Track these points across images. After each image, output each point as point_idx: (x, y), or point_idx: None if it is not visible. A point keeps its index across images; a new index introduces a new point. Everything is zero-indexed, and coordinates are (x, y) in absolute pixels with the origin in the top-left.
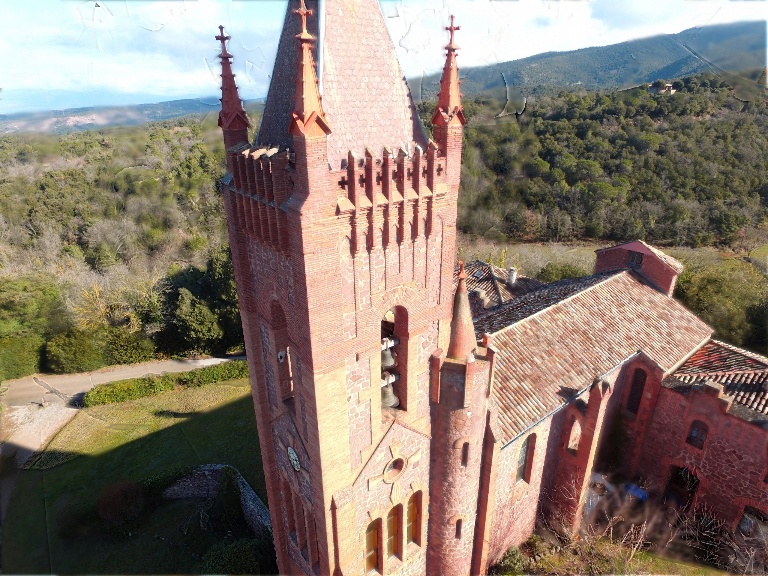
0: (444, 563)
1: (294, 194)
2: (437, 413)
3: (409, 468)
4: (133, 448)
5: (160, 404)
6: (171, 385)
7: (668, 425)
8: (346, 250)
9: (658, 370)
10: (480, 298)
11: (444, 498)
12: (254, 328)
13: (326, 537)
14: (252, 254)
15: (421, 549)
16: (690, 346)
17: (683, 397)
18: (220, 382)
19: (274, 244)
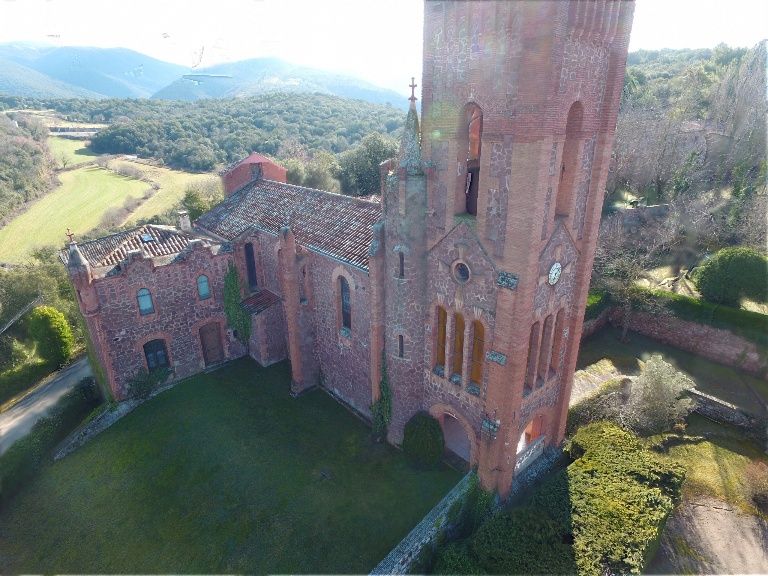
0: None
1: None
2: None
3: None
4: None
5: None
6: None
7: None
8: None
9: None
10: (204, 247)
11: None
12: None
13: None
14: None
15: None
16: None
17: None
18: None
19: None
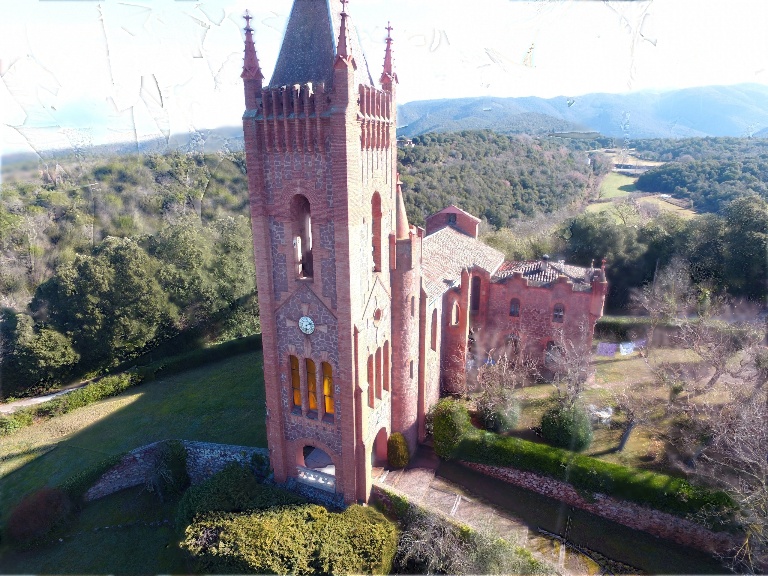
0: (404, 402)
1: (334, 106)
2: (394, 278)
3: (383, 319)
4: (12, 479)
5: (20, 440)
6: (28, 419)
7: (498, 309)
8: (359, 145)
9: (486, 273)
10: None
11: (402, 345)
12: (266, 229)
13: (351, 359)
14: (269, 168)
15: (389, 394)
16: (497, 262)
17: (503, 286)
18: (91, 403)
19: (310, 145)
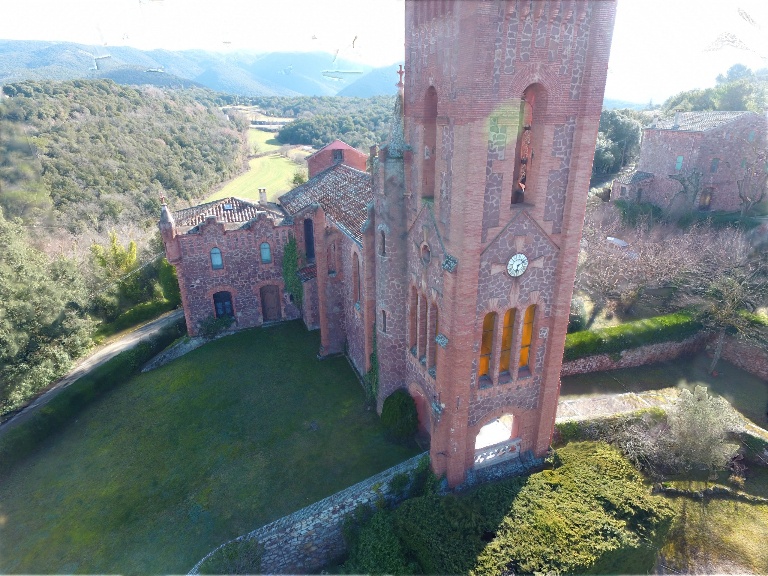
0: None
1: None
2: None
3: None
4: None
5: None
6: None
7: None
8: None
9: None
10: (267, 218)
11: None
12: None
13: None
14: (498, 43)
15: None
16: None
17: None
18: None
19: (572, 9)
